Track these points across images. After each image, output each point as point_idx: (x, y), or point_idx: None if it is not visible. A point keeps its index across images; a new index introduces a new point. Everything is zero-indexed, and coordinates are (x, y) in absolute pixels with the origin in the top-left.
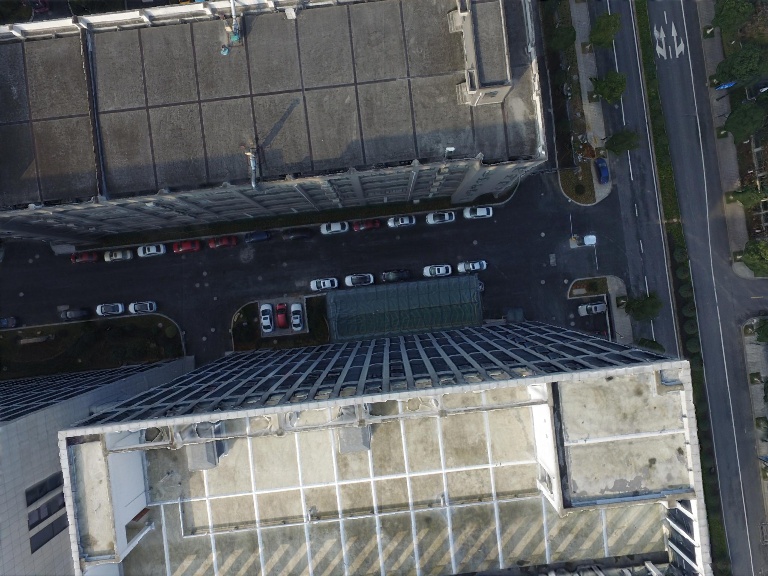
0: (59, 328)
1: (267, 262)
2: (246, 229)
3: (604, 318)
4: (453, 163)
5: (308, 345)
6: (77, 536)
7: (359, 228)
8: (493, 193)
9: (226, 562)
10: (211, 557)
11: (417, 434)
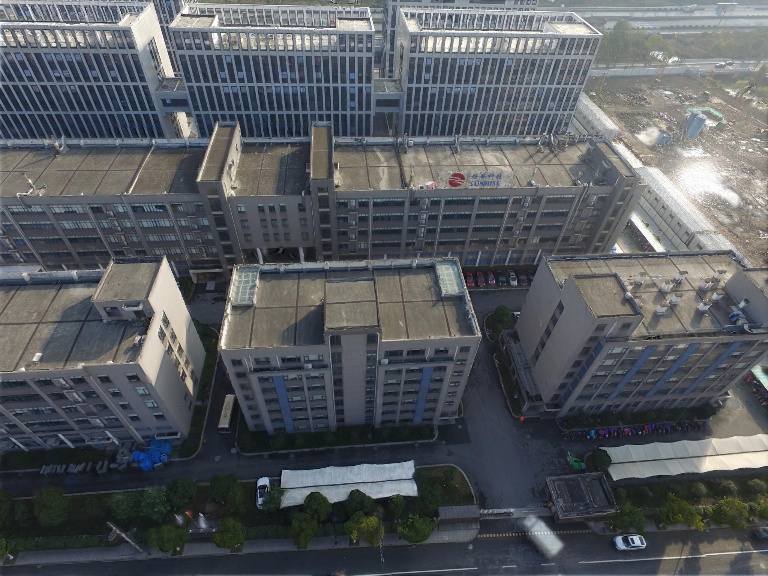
0: None
1: None
2: None
3: None
4: None
5: None
6: None
7: None
8: None
9: None
10: None
11: None
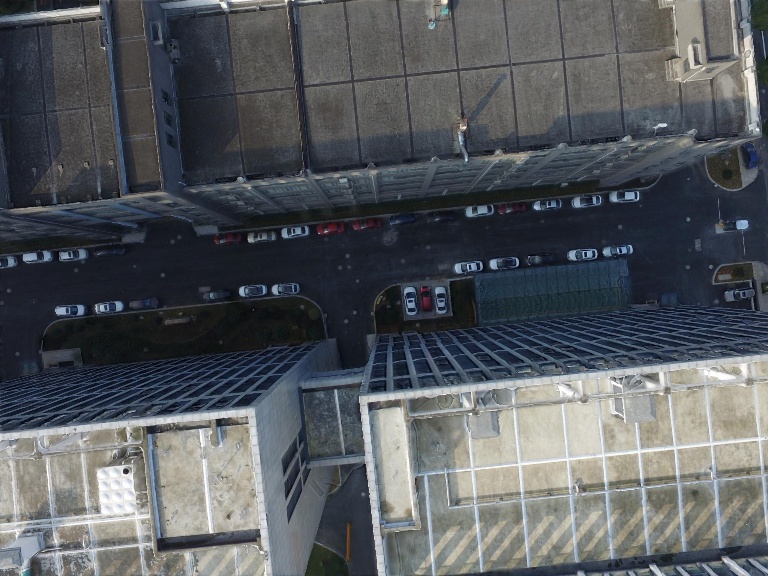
0: (201, 309)
1: (410, 245)
2: (390, 211)
3: (749, 304)
4: (663, 140)
5: (451, 328)
6: (378, 502)
7: (505, 211)
8: (640, 177)
9: (490, 534)
10: (475, 528)
11: (685, 406)
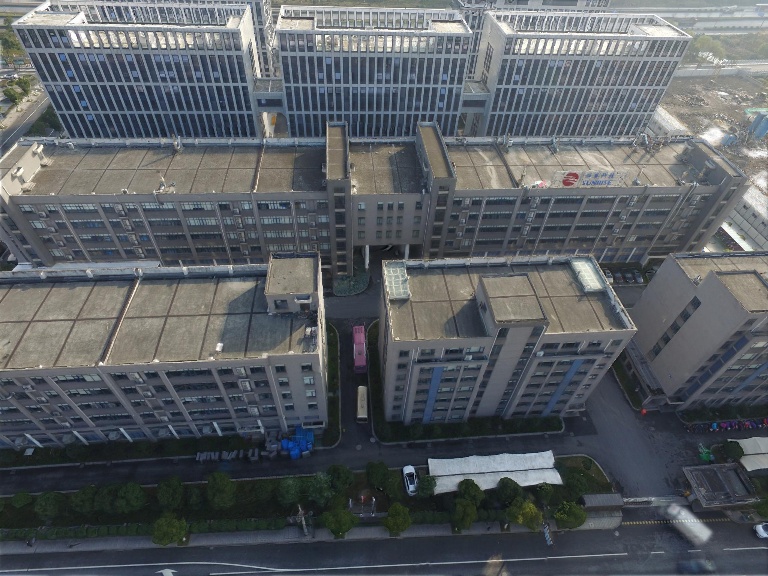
0: None
1: None
2: None
3: None
4: None
5: None
6: None
7: None
8: None
9: None
10: None
11: None
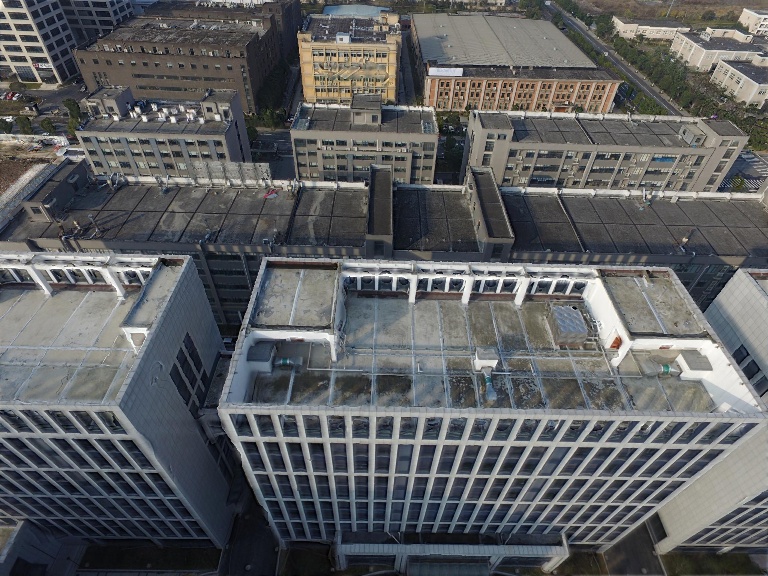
0: None
1: None
2: None
3: None
4: None
5: None
6: None
7: None
8: None
9: None
10: None
11: None
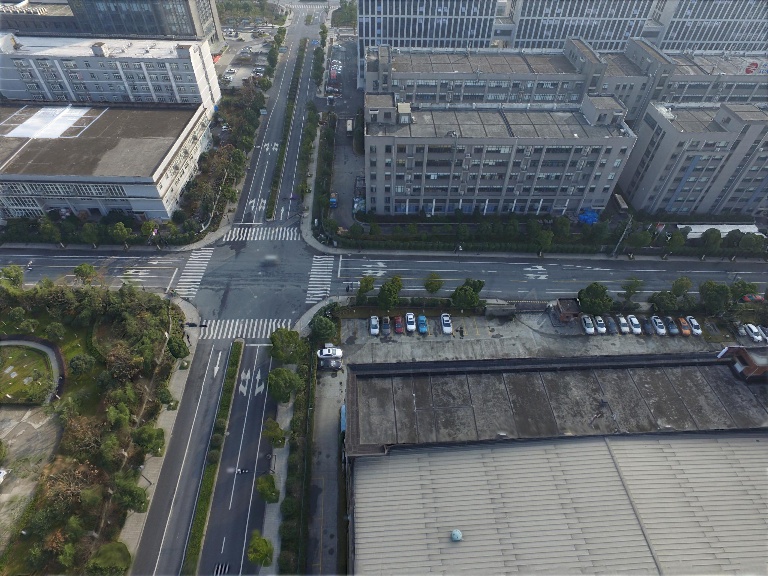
0: None
1: None
2: None
3: None
4: None
5: None
6: None
7: None
8: None
9: None
10: None
11: None
